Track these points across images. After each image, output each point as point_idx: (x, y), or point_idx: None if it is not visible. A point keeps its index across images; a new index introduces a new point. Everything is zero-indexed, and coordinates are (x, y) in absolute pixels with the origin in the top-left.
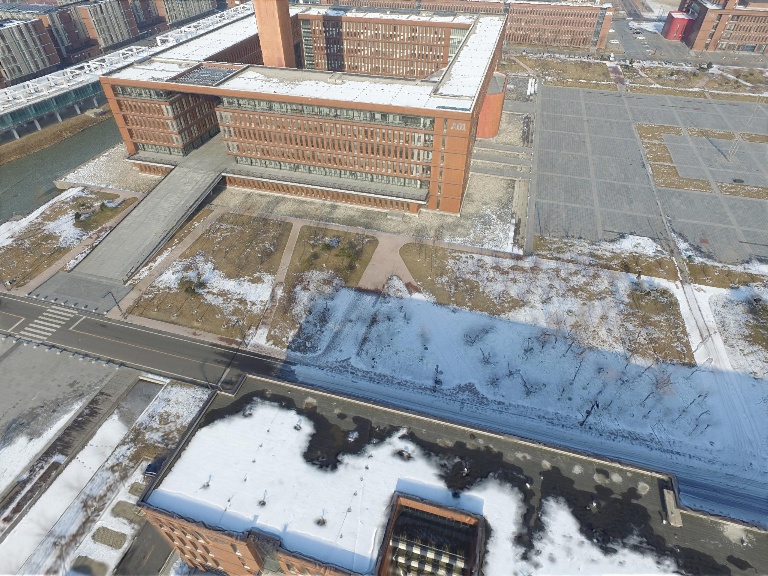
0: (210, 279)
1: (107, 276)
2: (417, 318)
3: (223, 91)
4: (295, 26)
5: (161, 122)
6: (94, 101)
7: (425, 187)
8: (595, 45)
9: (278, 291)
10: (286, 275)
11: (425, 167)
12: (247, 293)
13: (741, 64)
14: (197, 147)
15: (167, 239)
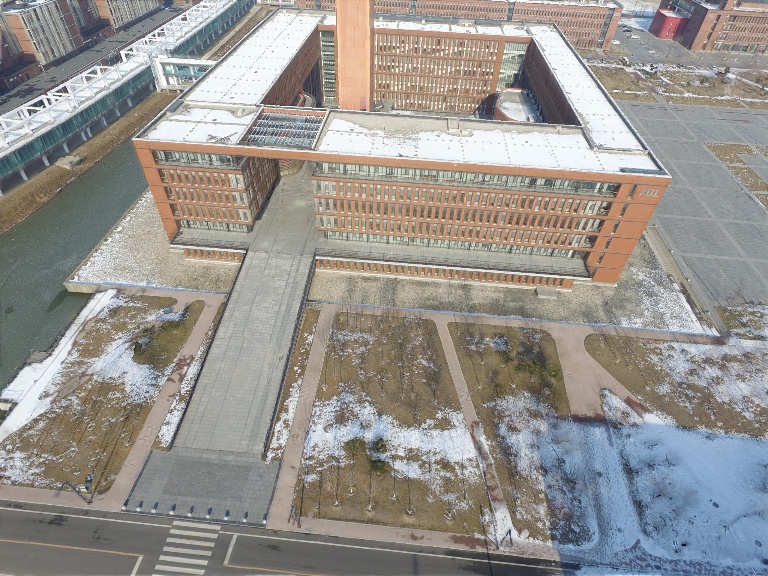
0: (384, 433)
1: (231, 449)
2: (673, 455)
3: (330, 156)
4: (316, 39)
5: (225, 195)
6: (64, 146)
7: (578, 256)
8: (600, 47)
9: (481, 438)
10: (475, 409)
11: (587, 236)
12: (445, 449)
13: (744, 66)
14: (258, 216)
15: (287, 371)
